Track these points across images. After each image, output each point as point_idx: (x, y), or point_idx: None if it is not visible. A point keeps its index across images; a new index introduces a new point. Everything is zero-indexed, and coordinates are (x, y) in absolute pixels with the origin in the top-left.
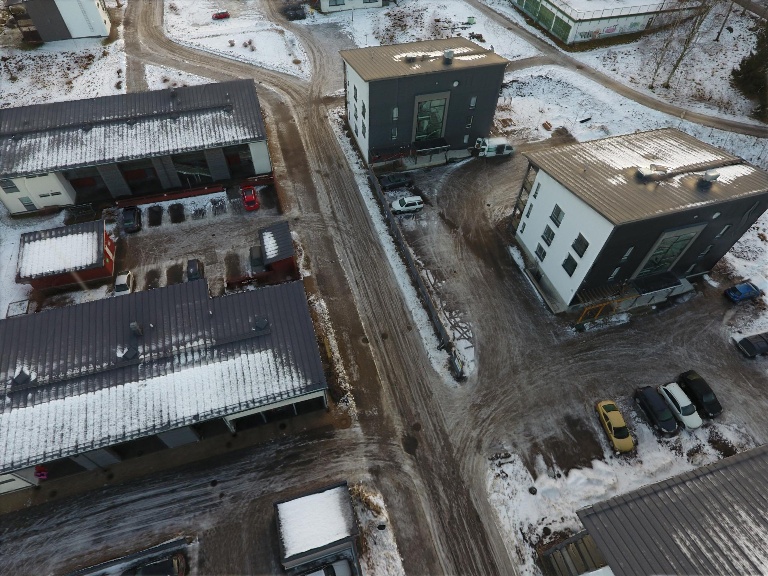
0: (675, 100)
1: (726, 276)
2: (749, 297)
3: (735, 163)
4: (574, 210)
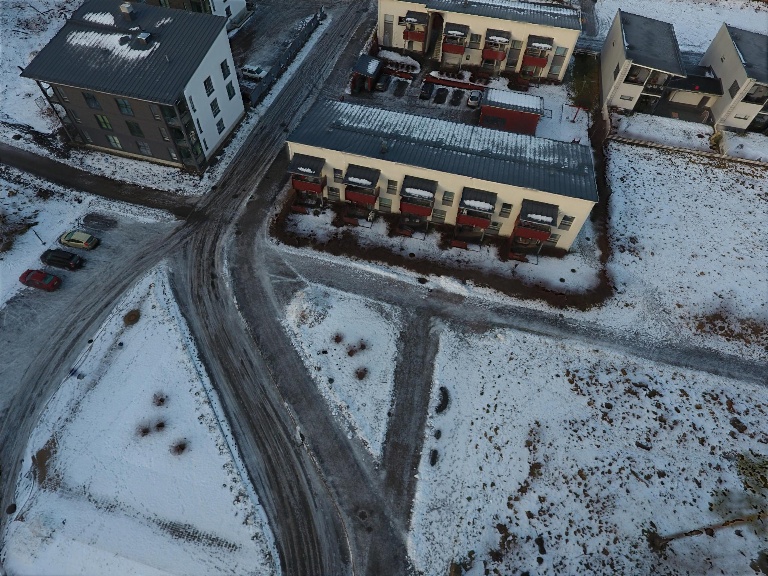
0: None
1: None
2: None
3: None
4: None
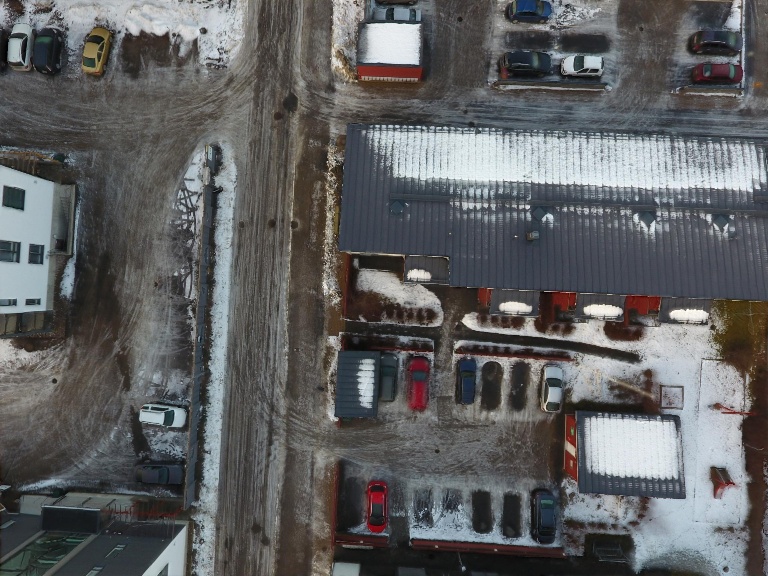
0: None
1: None
2: None
3: None
4: None
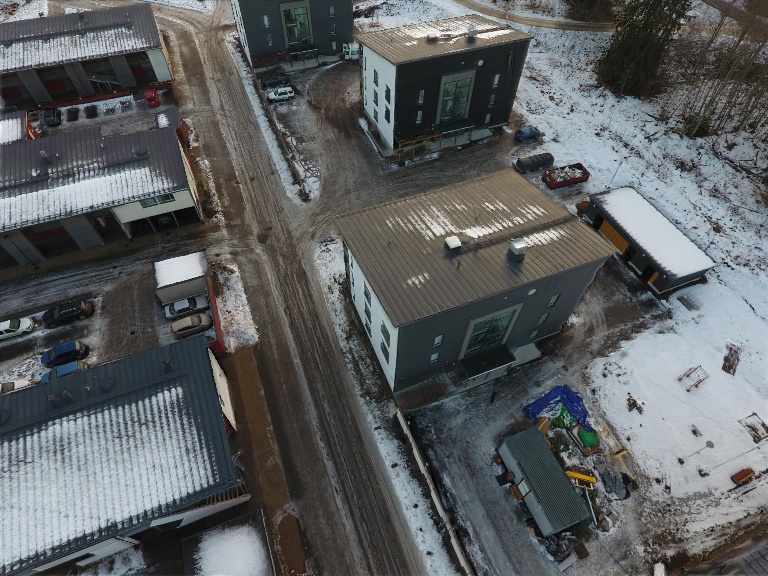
0: (511, 9)
1: (520, 126)
2: (532, 137)
3: (503, 29)
4: (381, 67)
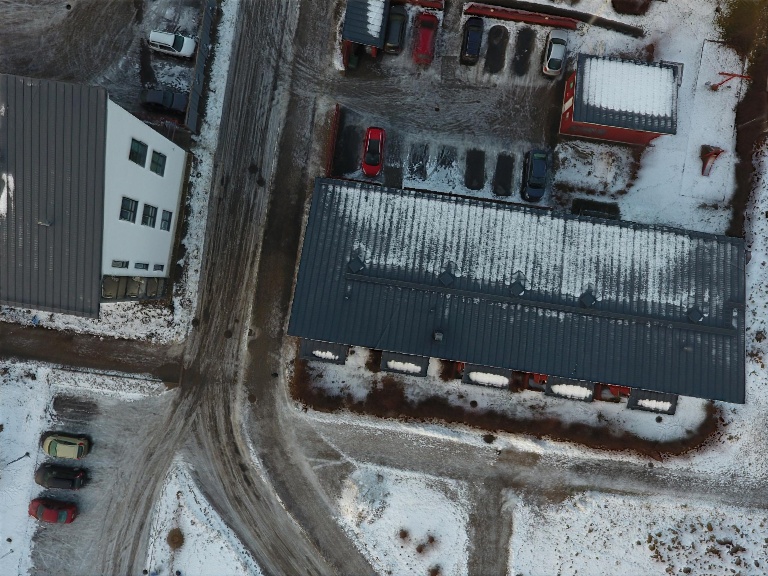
0: None
1: None
2: None
3: None
4: None
